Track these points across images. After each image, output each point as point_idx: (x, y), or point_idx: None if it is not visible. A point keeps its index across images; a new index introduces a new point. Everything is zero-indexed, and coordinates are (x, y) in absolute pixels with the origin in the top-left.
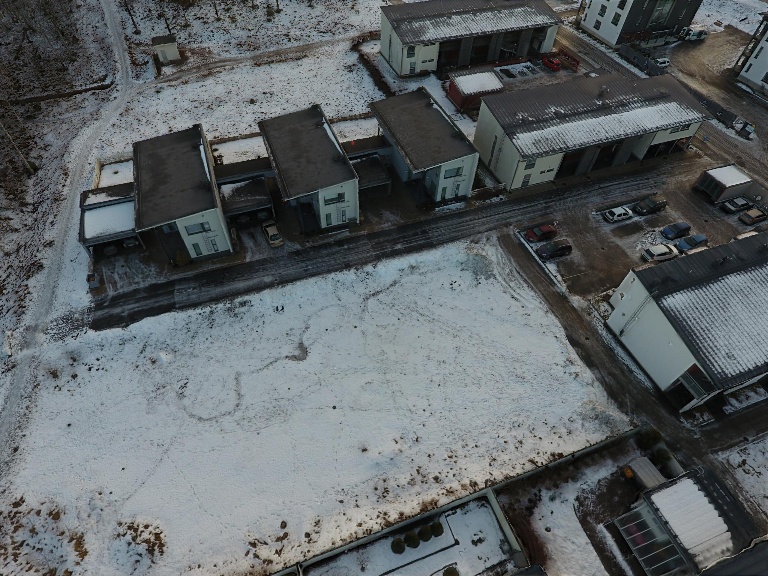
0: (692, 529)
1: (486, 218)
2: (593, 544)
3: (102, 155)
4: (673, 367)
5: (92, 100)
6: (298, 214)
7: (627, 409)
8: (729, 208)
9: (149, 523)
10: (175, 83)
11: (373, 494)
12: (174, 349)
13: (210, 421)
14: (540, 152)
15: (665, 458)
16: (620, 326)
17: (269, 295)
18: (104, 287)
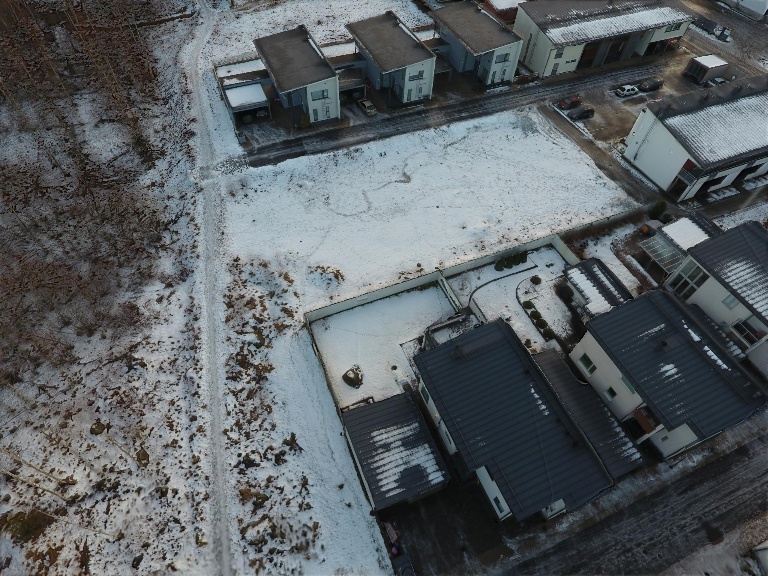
0: (688, 241)
1: (526, 96)
2: (624, 264)
3: (208, 63)
4: (673, 170)
5: (181, 26)
6: (382, 95)
7: (641, 201)
8: (711, 85)
9: (329, 266)
10: (249, 11)
11: (475, 249)
12: (313, 179)
13: (352, 216)
14: (568, 42)
15: (669, 219)
16: (634, 154)
17: (374, 145)
18: (250, 142)
